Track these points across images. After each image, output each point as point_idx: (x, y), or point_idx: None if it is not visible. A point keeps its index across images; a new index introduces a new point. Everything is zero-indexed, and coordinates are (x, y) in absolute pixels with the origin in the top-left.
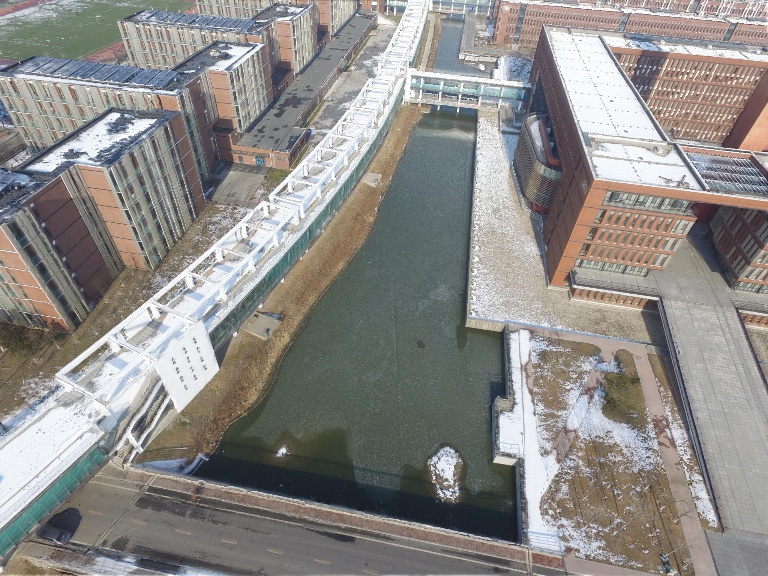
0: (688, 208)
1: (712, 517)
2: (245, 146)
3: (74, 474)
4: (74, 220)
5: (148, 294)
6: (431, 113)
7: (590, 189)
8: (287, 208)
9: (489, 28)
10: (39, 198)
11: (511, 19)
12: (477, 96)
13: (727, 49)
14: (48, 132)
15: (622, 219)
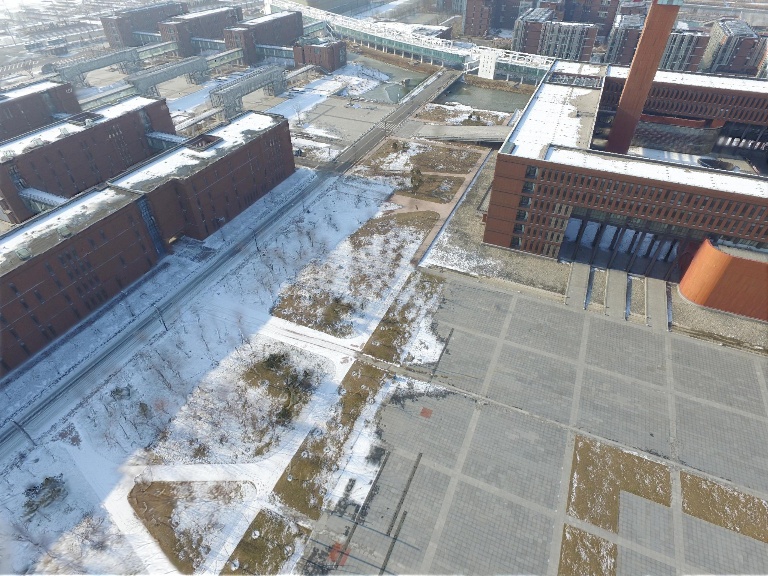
0: None
1: None
2: None
3: (458, 59)
4: (537, 39)
5: None
6: None
7: None
8: None
9: None
10: (532, 24)
11: None
12: None
13: None
14: None
15: None
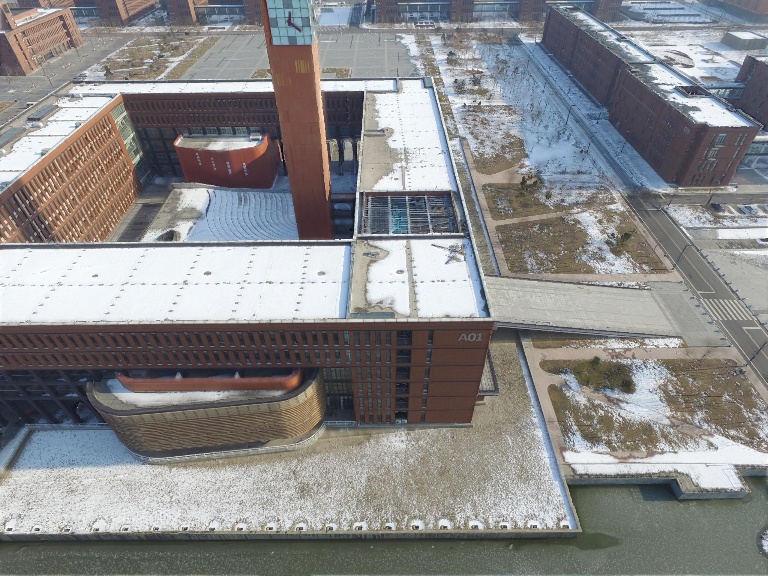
0: None
1: (676, 340)
2: None
3: None
4: None
5: None
6: None
7: None
8: None
9: None
10: None
11: None
12: None
13: (13, 141)
14: None
15: None
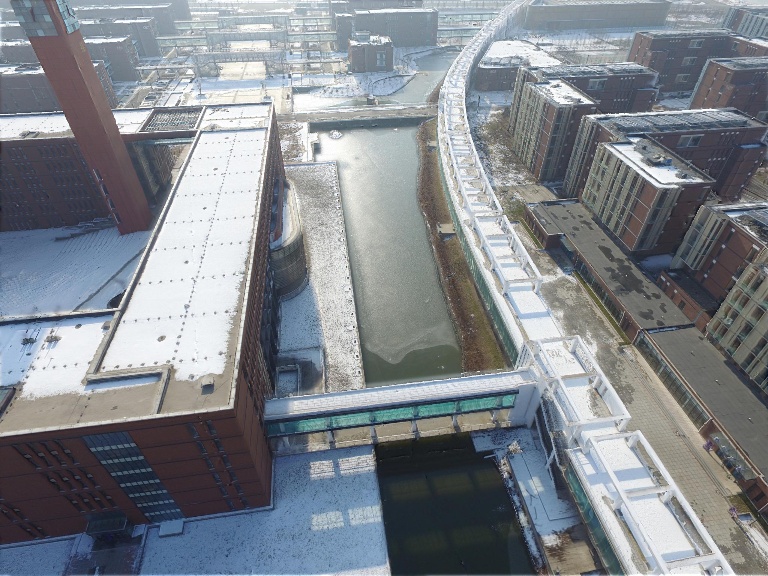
0: None
1: None
2: None
3: None
4: None
5: None
6: None
7: None
8: None
9: None
10: None
11: None
12: None
13: None
14: None
15: None
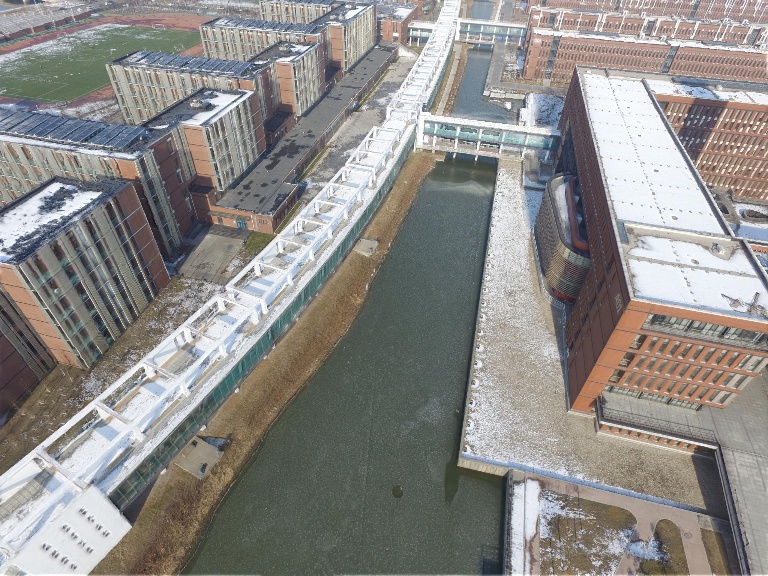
0: (762, 340)
1: None
2: (224, 207)
3: None
4: None
5: (74, 404)
6: (446, 161)
7: (625, 310)
8: (243, 305)
9: (519, 60)
10: None
11: (543, 52)
12: (498, 143)
13: None
14: (7, 192)
15: (668, 347)
